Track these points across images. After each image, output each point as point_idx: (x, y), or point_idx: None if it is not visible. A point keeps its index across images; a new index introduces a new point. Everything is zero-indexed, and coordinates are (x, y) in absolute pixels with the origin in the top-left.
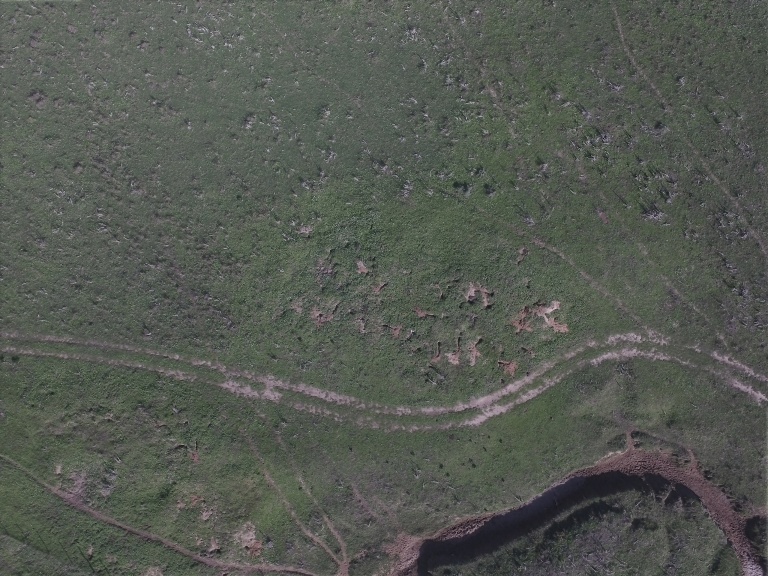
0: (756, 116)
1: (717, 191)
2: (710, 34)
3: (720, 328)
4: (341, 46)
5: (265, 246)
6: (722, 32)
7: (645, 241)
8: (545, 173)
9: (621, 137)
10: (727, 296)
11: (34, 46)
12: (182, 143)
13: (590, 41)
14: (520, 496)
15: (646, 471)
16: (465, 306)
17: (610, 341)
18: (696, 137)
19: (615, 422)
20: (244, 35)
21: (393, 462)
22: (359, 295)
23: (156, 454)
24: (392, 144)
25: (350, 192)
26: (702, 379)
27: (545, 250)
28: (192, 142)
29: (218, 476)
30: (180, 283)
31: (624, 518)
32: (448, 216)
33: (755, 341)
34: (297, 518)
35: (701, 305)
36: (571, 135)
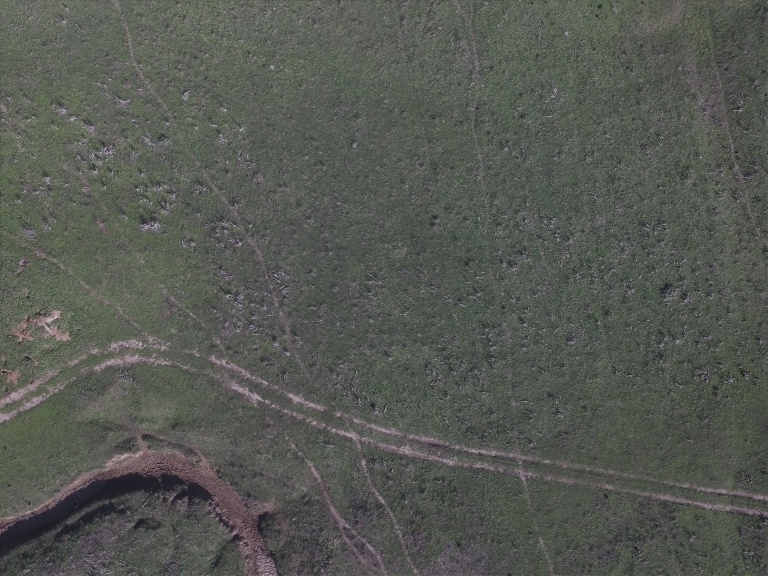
0: (259, 128)
1: (216, 201)
2: (217, 49)
3: (216, 333)
4: None
5: None
6: (229, 47)
7: (142, 250)
8: (49, 186)
9: (125, 150)
10: (223, 302)
11: None
12: None
13: (100, 56)
14: (30, 501)
15: (164, 472)
16: None
17: (113, 348)
18: (199, 149)
19: (125, 426)
20: None
21: None
22: None
23: None
24: None
25: None
26: (202, 382)
27: (45, 261)
28: None
29: None
30: None
31: (127, 519)
32: None
33: (250, 344)
34: None
35: (196, 311)
36: (77, 148)
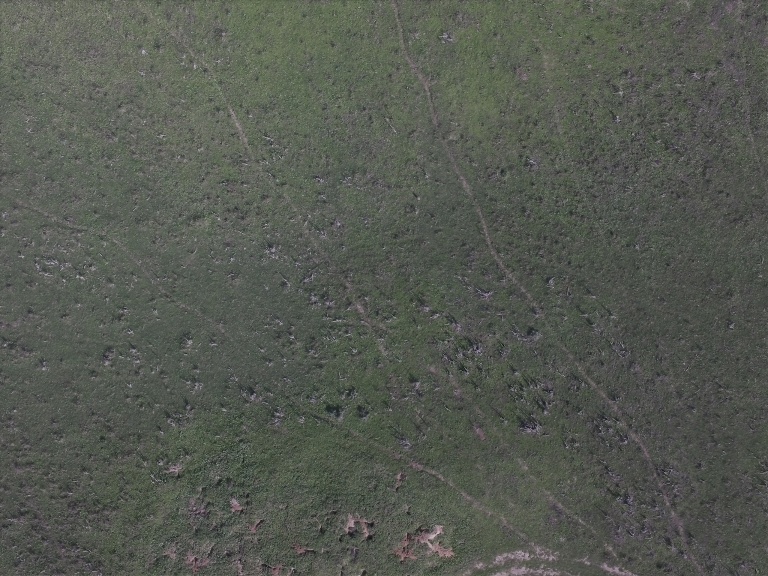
0: (629, 313)
1: (595, 396)
2: (577, 230)
3: (608, 539)
4: (199, 269)
5: (133, 489)
6: (589, 228)
7: (525, 456)
8: (418, 391)
9: (494, 346)
10: (612, 505)
11: None
12: (38, 385)
13: (456, 246)
14: None
15: None
16: (345, 539)
17: (498, 560)
18: (570, 340)
19: None
20: (96, 265)
21: None
22: (234, 535)
23: None
24: (260, 369)
25: (219, 423)
26: None
27: (423, 473)
28: (49, 383)
29: None
30: (45, 535)
31: None
32: (322, 443)
33: (644, 549)
34: None
35: (586, 517)
36: (443, 348)
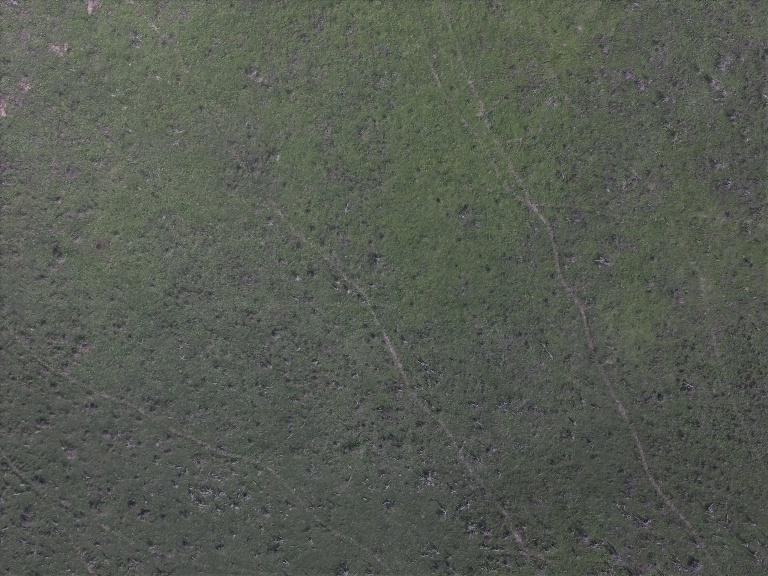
0: None
1: None
2: (735, 455)
3: None
4: (354, 497)
5: None
6: (747, 451)
7: None
8: None
9: None
10: None
11: (25, 526)
12: None
13: (613, 472)
14: None
15: None
16: None
17: None
18: (731, 569)
19: None
20: (251, 494)
21: None
22: None
23: None
24: None
25: None
26: None
27: None
28: None
29: None
30: None
31: None
32: None
33: None
34: None
35: None
36: None
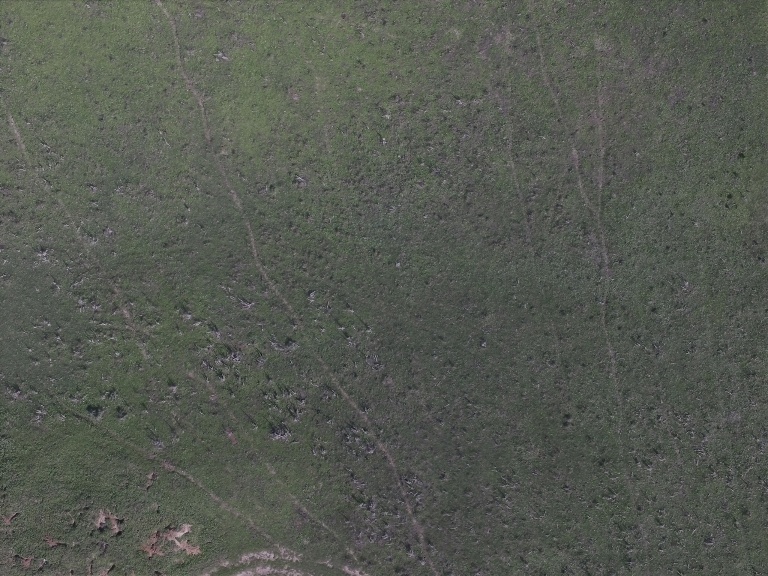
0: (386, 328)
1: (345, 406)
2: (341, 247)
3: (349, 544)
4: None
5: None
6: (353, 244)
7: (273, 461)
8: (176, 394)
9: (252, 355)
10: (356, 511)
11: None
12: None
13: (223, 257)
14: None
15: None
16: (95, 534)
17: (244, 560)
18: (326, 352)
19: None
20: None
21: None
22: None
23: None
24: (27, 367)
25: None
26: None
27: (174, 474)
28: None
29: None
30: None
31: None
32: (80, 441)
33: (384, 555)
34: None
35: (329, 522)
36: (203, 354)
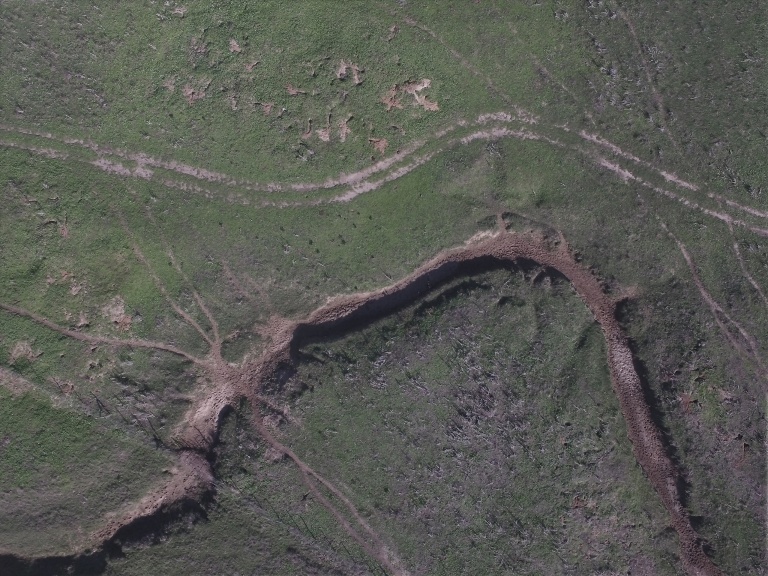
0: None
1: None
2: None
3: (588, 106)
4: None
5: (139, 26)
6: None
7: (515, 20)
8: None
9: None
10: (595, 75)
11: None
12: None
13: None
14: (390, 275)
15: (518, 255)
16: (336, 83)
17: (480, 120)
18: None
19: (486, 203)
20: None
21: (263, 238)
22: (231, 73)
23: (26, 230)
24: None
25: None
26: (571, 158)
27: (416, 28)
28: None
29: (88, 251)
30: (54, 63)
31: (492, 294)
32: None
33: (622, 119)
34: (167, 294)
35: (569, 83)
36: None
